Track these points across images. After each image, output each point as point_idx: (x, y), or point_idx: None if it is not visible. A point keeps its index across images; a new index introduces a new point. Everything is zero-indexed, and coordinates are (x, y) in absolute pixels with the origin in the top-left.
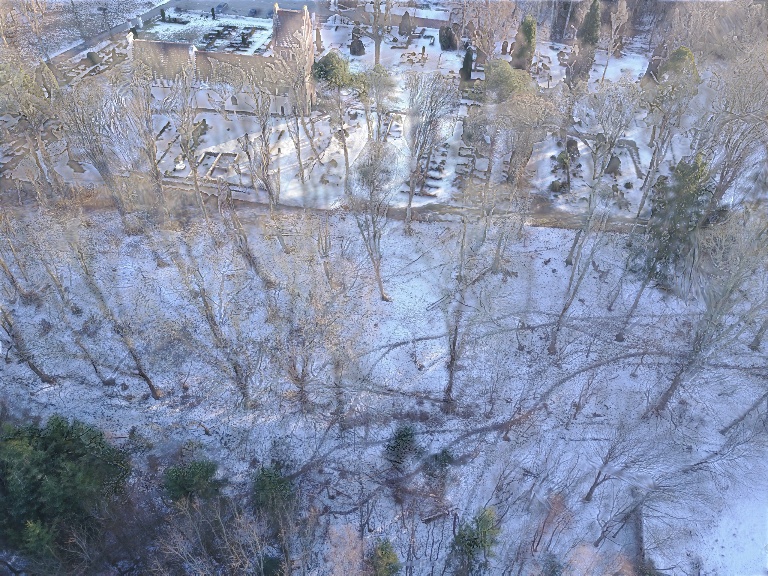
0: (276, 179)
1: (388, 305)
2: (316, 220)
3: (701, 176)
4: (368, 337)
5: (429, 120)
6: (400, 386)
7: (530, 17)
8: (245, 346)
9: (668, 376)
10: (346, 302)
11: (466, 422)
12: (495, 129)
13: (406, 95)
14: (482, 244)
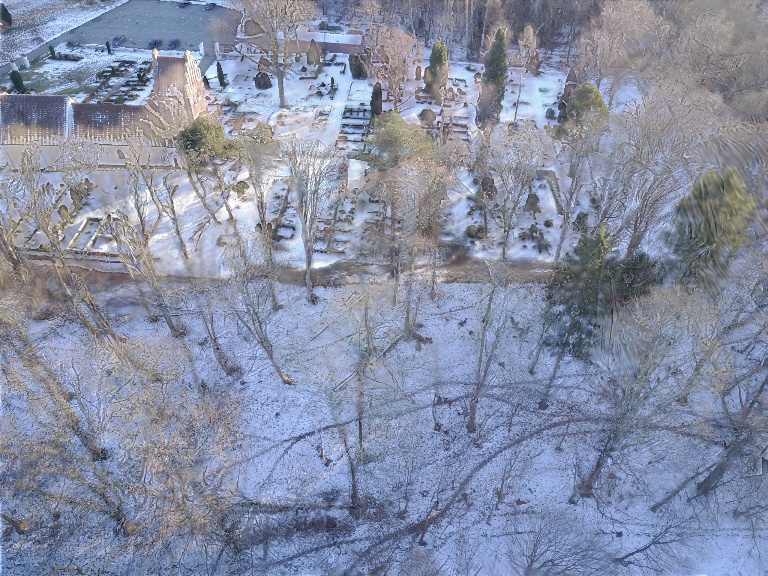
0: (147, 264)
1: (291, 389)
2: (209, 293)
3: (613, 229)
4: (269, 430)
5: (314, 188)
6: (304, 488)
7: (439, 43)
8: (128, 455)
9: (595, 446)
10: (244, 389)
11: (378, 526)
12: (393, 188)
13: (285, 163)
14: (393, 308)
